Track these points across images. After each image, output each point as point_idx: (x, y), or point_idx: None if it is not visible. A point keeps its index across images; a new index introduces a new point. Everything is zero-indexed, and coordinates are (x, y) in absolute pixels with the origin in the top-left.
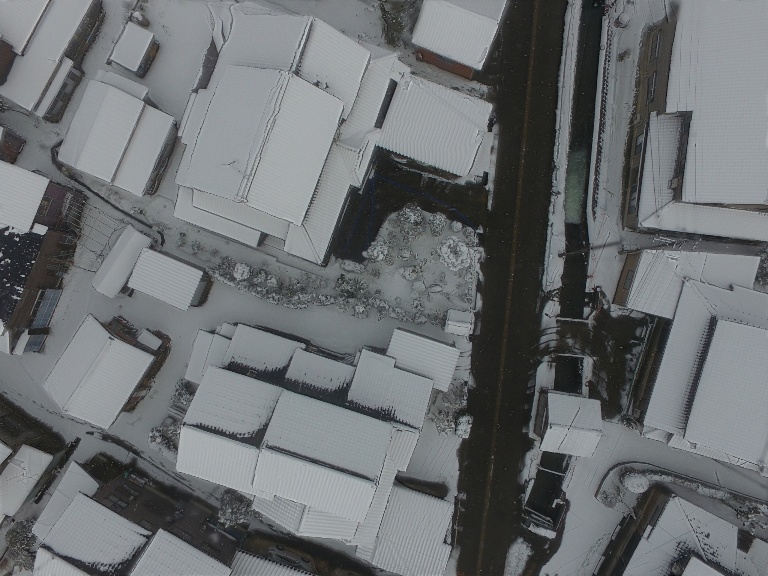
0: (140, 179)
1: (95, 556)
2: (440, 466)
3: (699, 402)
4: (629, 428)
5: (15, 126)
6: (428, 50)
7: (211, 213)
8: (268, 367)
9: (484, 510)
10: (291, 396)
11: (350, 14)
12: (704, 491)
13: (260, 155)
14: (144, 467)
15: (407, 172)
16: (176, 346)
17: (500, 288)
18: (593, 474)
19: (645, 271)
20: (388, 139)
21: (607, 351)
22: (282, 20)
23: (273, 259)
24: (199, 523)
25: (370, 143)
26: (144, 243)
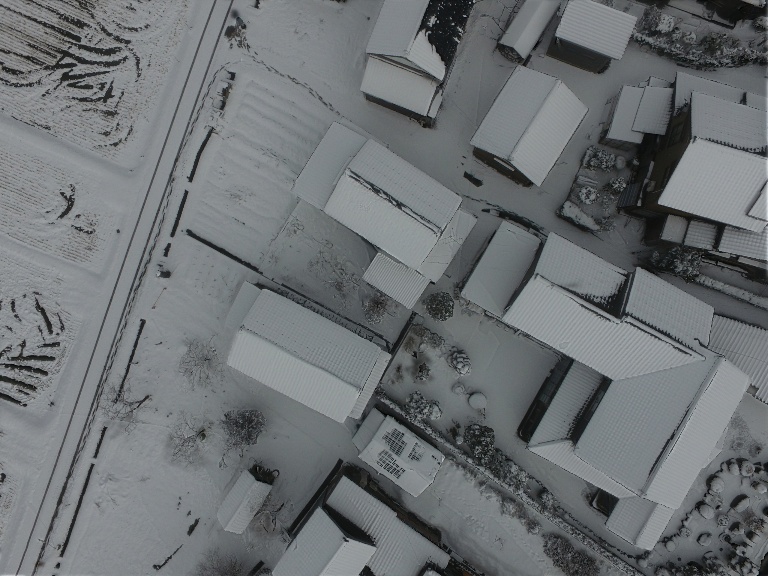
0: None
1: (586, 288)
2: None
3: None
4: None
5: None
6: None
7: None
8: None
9: None
10: None
11: None
12: None
13: None
14: None
15: None
16: None
17: None
18: None
19: None
20: None
21: None
22: None
23: None
24: None
25: None
26: None
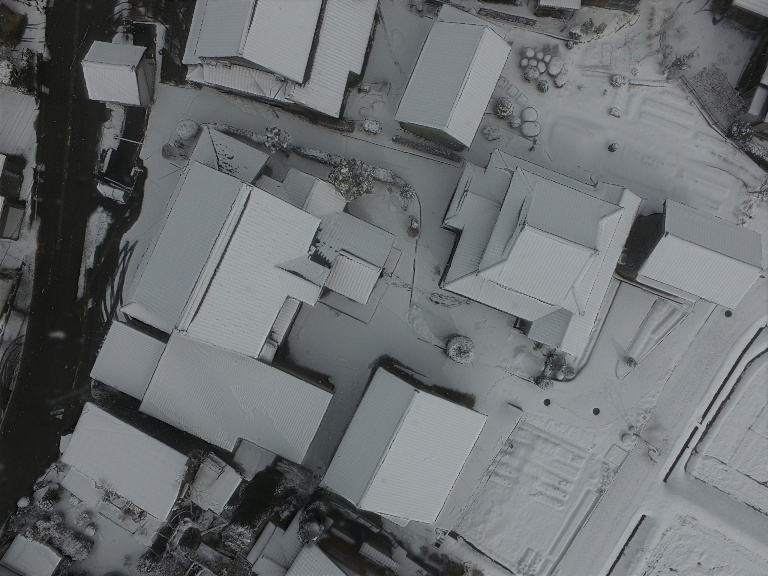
0: None
1: None
2: (17, 138)
3: (205, 16)
4: None
5: None
6: None
7: None
8: None
9: (62, 180)
10: None
11: None
12: (258, 138)
13: None
14: None
15: None
16: None
17: None
18: (168, 140)
19: None
20: None
21: (179, 18)
22: None
23: None
24: None
25: None
26: None
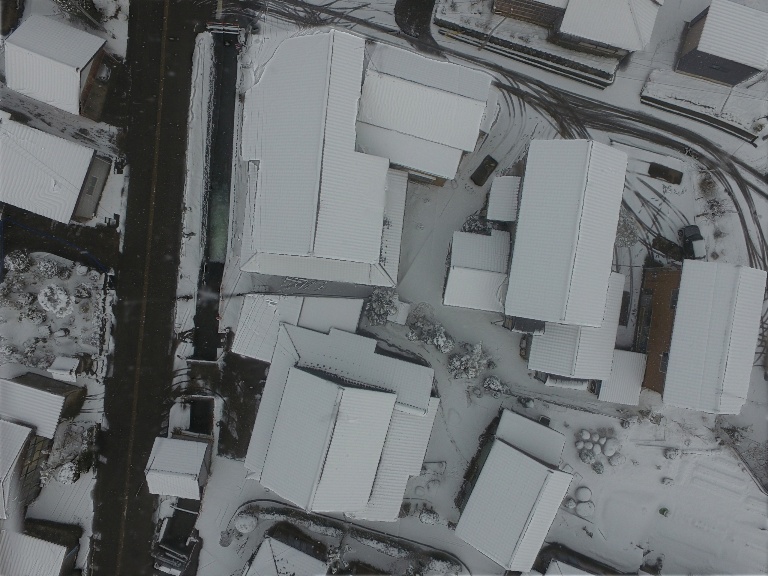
0: None
1: None
2: (74, 508)
3: (271, 448)
4: None
5: None
6: (26, 96)
7: None
8: None
9: (118, 550)
10: None
11: None
12: (316, 528)
13: None
14: None
15: (37, 215)
16: None
17: (132, 330)
18: (224, 512)
19: (247, 316)
20: None
21: (237, 391)
22: None
23: None
24: None
25: None
26: None
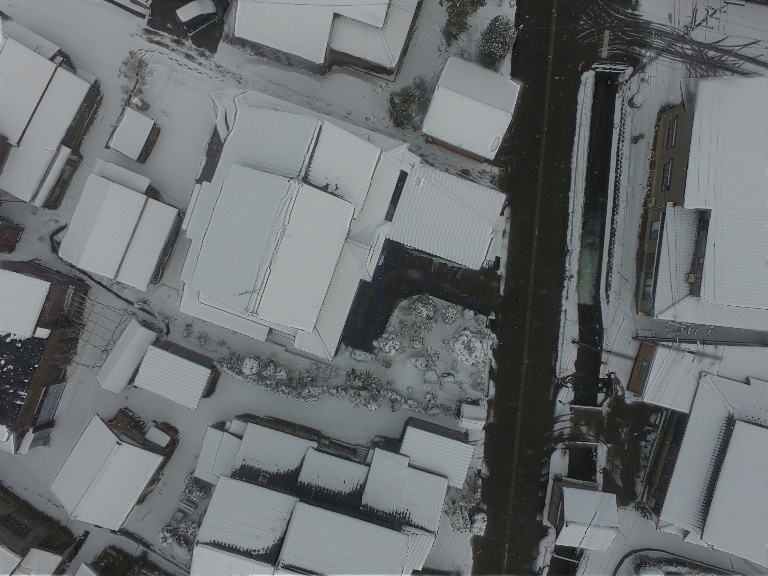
0: (144, 273)
1: None
2: (454, 555)
3: (717, 504)
4: (644, 518)
5: (12, 215)
6: (439, 139)
7: (218, 309)
8: (280, 469)
9: None
10: (305, 509)
11: (357, 96)
12: None
13: (270, 266)
14: (154, 560)
15: (417, 257)
16: (184, 438)
17: (513, 375)
18: (607, 561)
19: (661, 364)
20: (399, 234)
21: (621, 438)
22: (289, 117)
23: (282, 349)
24: None
25: (381, 237)
26: (149, 338)
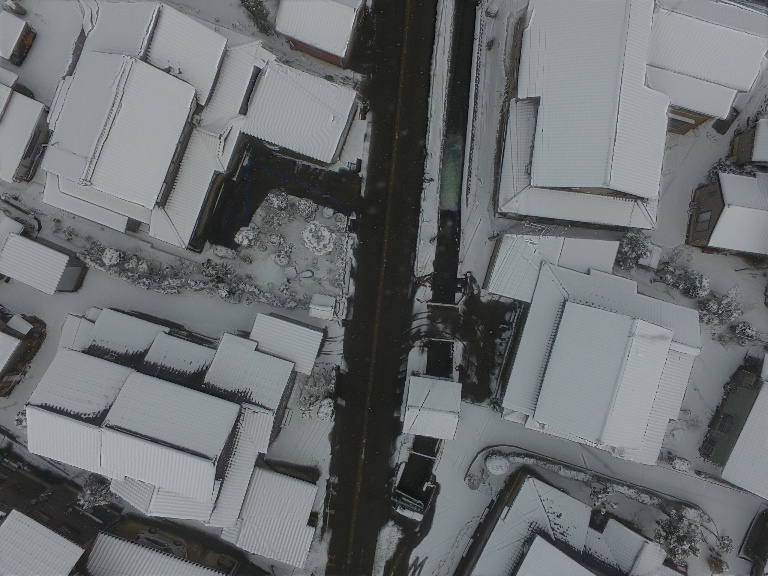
0: (10, 165)
1: None
2: (312, 450)
3: (547, 383)
4: (495, 411)
5: None
6: (292, 38)
7: (78, 198)
8: (129, 350)
9: (355, 493)
10: (139, 377)
11: (224, 3)
12: (566, 473)
13: (106, 139)
14: (19, 452)
15: (281, 159)
16: (52, 331)
17: (372, 274)
18: (462, 457)
19: (505, 255)
20: (250, 125)
21: (477, 336)
22: (139, 7)
23: (148, 245)
24: (65, 506)
25: (234, 129)
26: (15, 229)
